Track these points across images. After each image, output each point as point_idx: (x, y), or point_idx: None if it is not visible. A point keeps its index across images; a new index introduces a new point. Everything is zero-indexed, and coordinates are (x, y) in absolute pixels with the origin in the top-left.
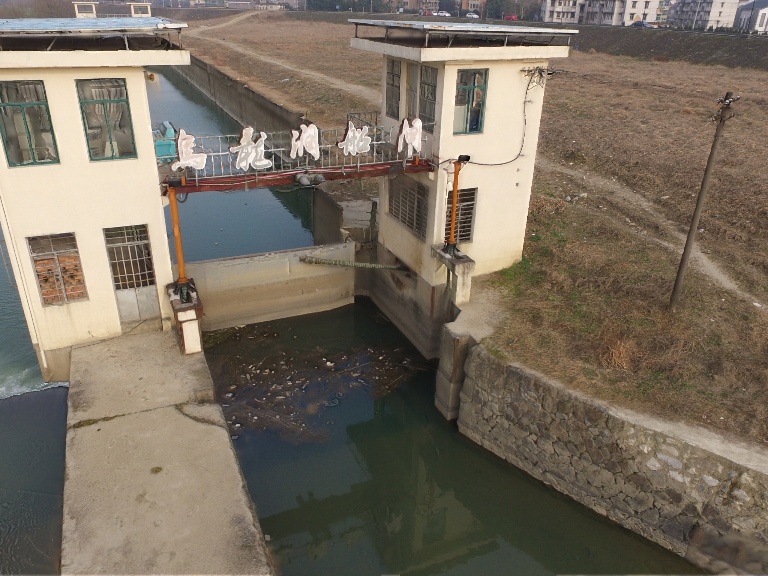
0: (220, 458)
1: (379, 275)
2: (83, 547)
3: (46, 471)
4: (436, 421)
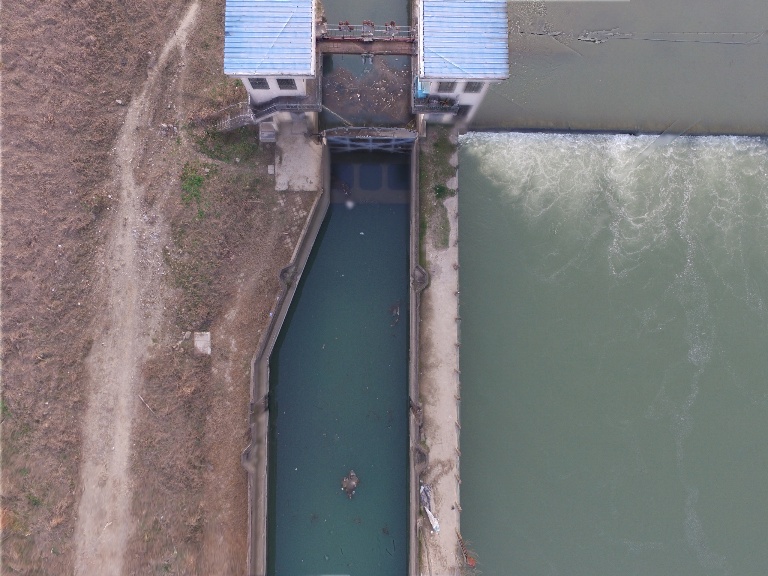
0: None
1: None
2: None
3: None
4: None
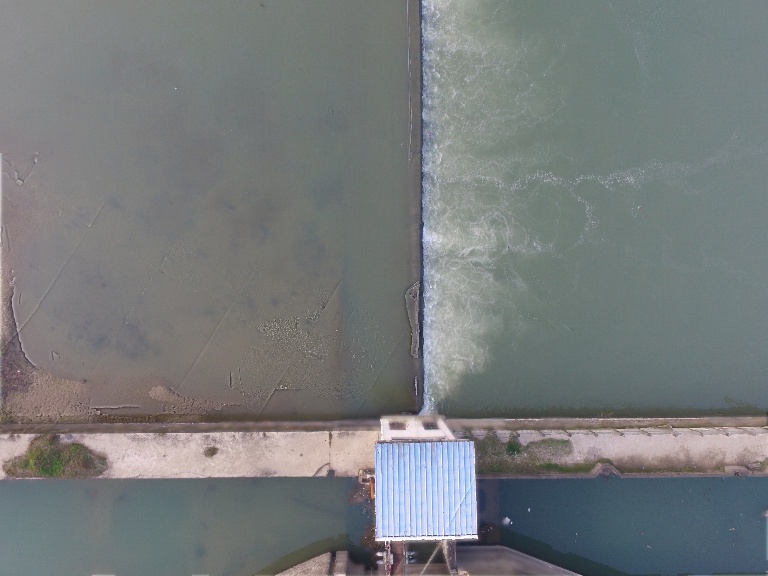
0: (300, 472)
1: (437, 574)
2: (281, 437)
3: (372, 405)
4: (343, 547)
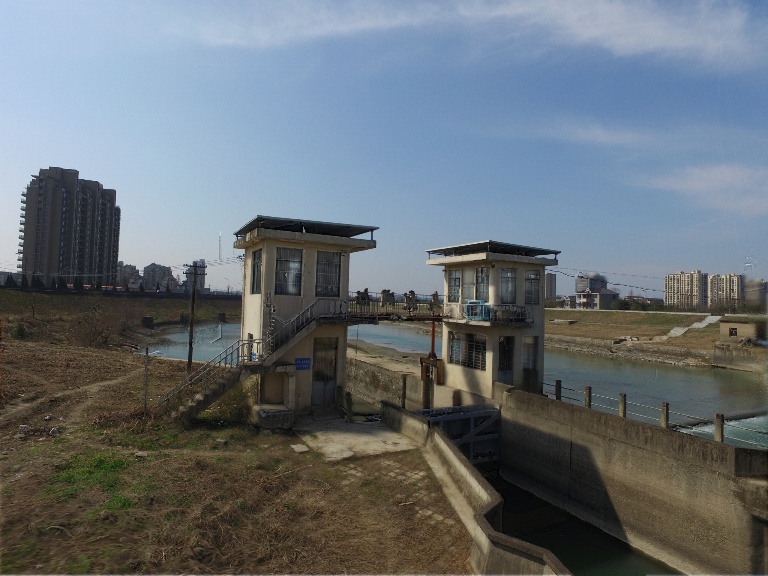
0: None
1: None
2: None
3: None
4: None
